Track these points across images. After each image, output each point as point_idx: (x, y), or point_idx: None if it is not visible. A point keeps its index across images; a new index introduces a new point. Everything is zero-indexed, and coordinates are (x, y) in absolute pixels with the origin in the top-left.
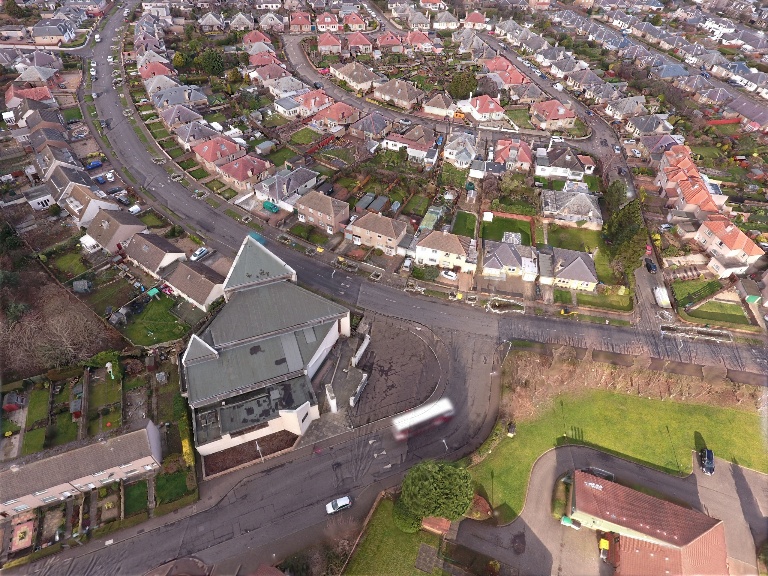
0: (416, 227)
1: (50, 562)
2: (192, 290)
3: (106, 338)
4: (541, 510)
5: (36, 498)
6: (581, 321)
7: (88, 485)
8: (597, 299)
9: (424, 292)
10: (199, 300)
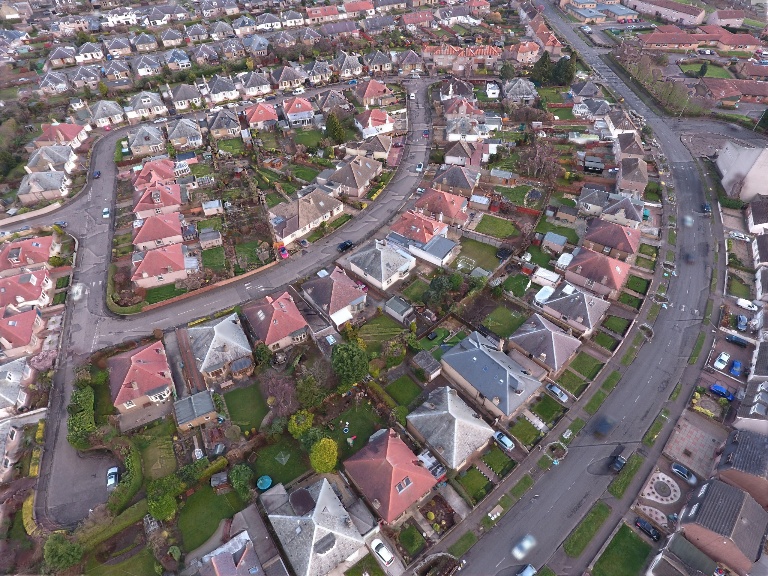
0: None
1: None
2: None
3: None
4: None
5: None
6: None
7: None
8: None
9: None
10: None
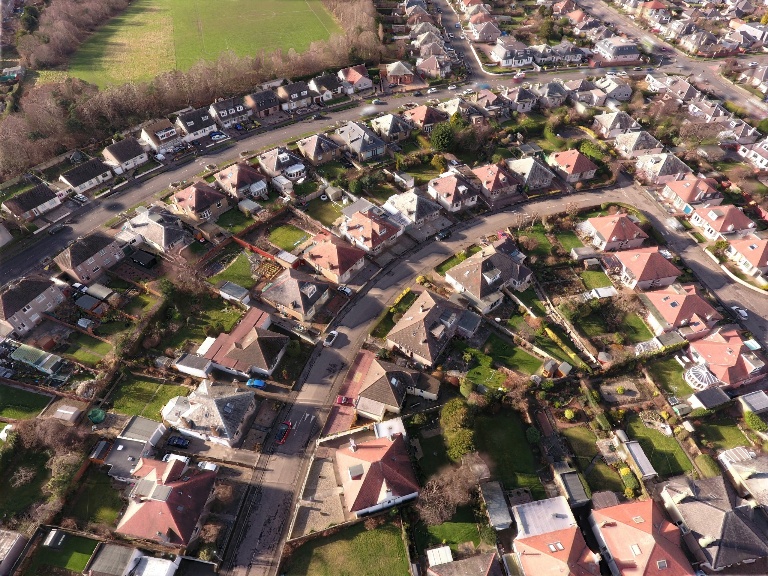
0: None
1: None
2: None
3: (4, 175)
4: None
5: None
6: None
7: None
8: None
9: None
10: None
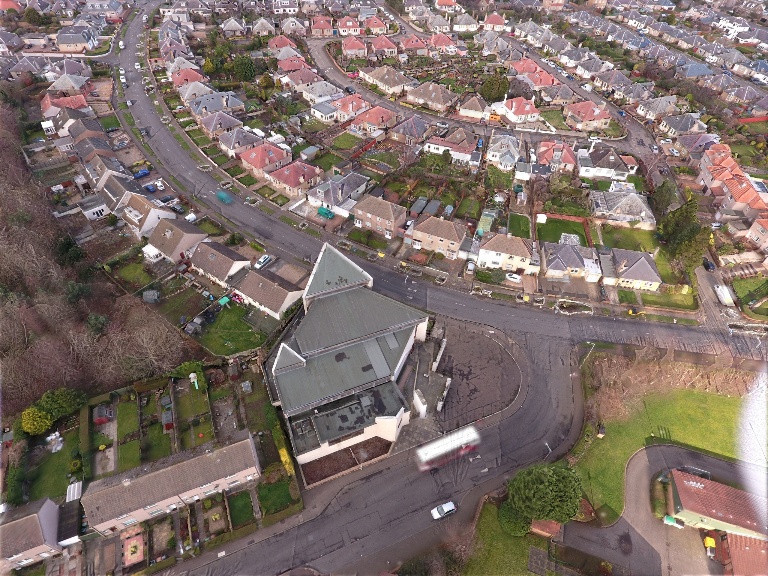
0: (473, 230)
1: (166, 575)
2: (265, 298)
3: (186, 348)
4: (641, 510)
5: (145, 512)
6: (649, 321)
7: (193, 497)
8: (661, 298)
9: (491, 295)
10: (273, 308)
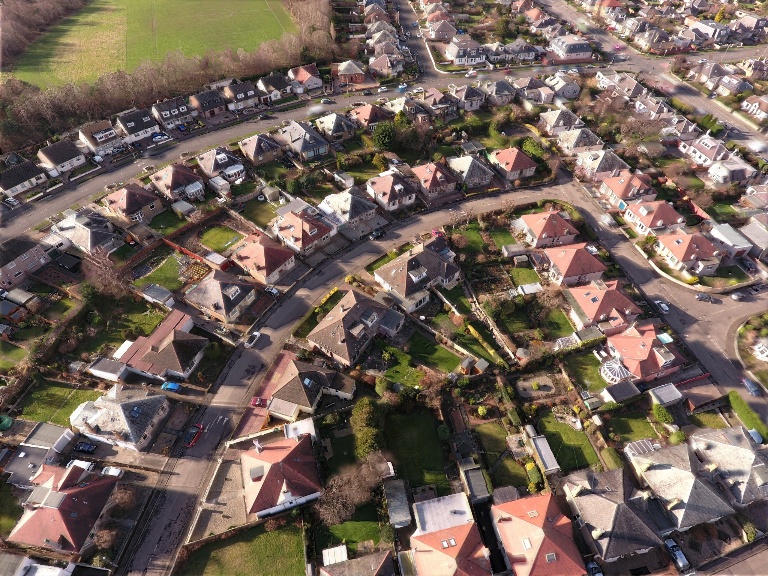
0: None
1: None
2: None
3: None
4: None
5: None
6: None
7: None
8: None
9: None
10: None
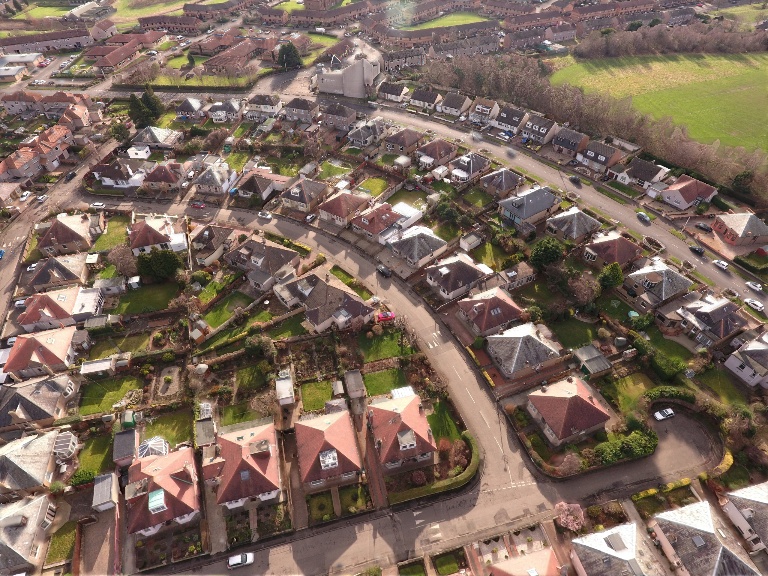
0: None
1: None
2: None
3: None
4: None
5: None
6: None
7: None
8: None
9: None
10: None
